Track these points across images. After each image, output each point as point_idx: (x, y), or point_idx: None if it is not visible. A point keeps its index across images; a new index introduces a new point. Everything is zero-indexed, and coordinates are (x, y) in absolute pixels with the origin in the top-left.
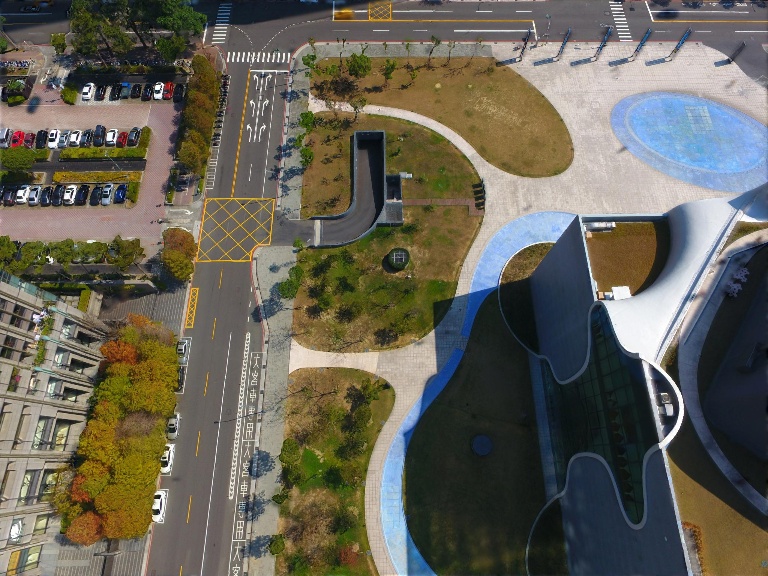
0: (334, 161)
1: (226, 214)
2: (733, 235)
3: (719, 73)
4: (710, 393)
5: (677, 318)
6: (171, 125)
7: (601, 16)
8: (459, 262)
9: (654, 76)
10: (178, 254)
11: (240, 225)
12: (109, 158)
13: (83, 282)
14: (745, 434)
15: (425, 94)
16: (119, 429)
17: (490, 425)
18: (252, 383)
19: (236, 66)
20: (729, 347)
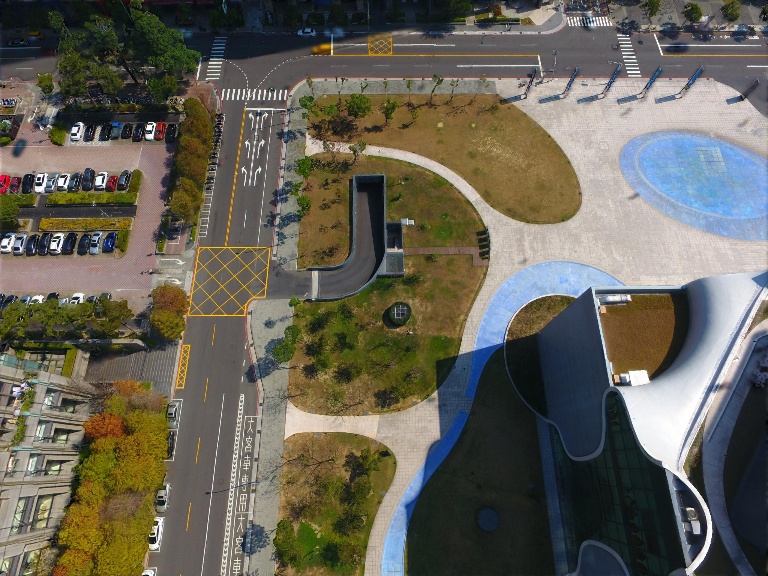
0: (332, 207)
1: (219, 264)
2: (758, 316)
3: (731, 111)
4: (738, 499)
5: (700, 412)
6: (163, 168)
7: (608, 50)
8: (463, 316)
9: (664, 114)
10: (168, 314)
11: (234, 276)
12: (98, 204)
13: (69, 341)
14: None
15: (427, 134)
16: (103, 512)
17: (496, 496)
18: (246, 450)
19: (231, 104)
20: (757, 445)
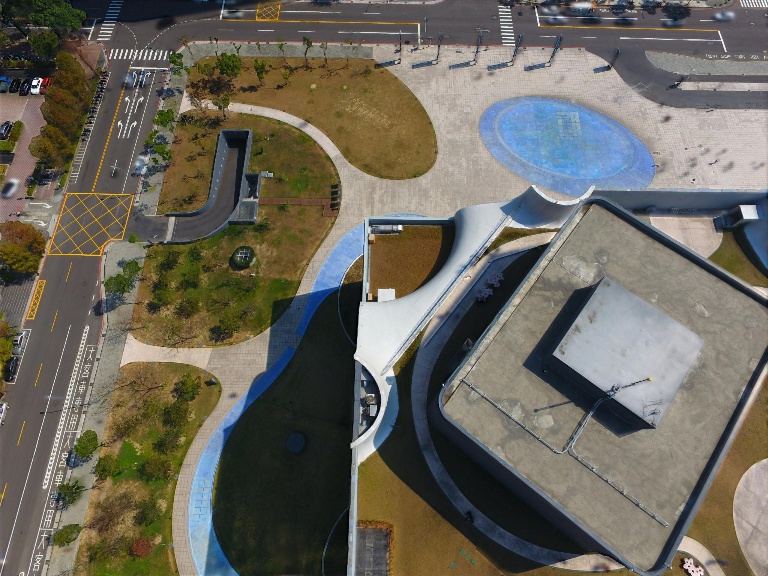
0: (198, 159)
1: (84, 209)
2: (498, 240)
3: (597, 79)
4: (436, 396)
5: (422, 321)
6: (44, 120)
7: (488, 20)
8: (305, 261)
9: (531, 81)
10: (12, 247)
11: (96, 220)
12: None
13: None
14: (454, 437)
15: (299, 94)
16: None
17: (309, 423)
18: (83, 375)
19: (117, 63)
20: None
